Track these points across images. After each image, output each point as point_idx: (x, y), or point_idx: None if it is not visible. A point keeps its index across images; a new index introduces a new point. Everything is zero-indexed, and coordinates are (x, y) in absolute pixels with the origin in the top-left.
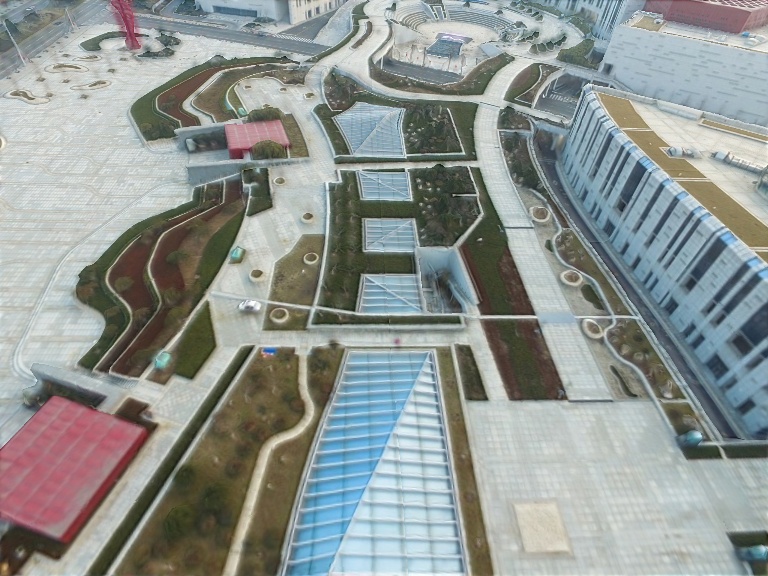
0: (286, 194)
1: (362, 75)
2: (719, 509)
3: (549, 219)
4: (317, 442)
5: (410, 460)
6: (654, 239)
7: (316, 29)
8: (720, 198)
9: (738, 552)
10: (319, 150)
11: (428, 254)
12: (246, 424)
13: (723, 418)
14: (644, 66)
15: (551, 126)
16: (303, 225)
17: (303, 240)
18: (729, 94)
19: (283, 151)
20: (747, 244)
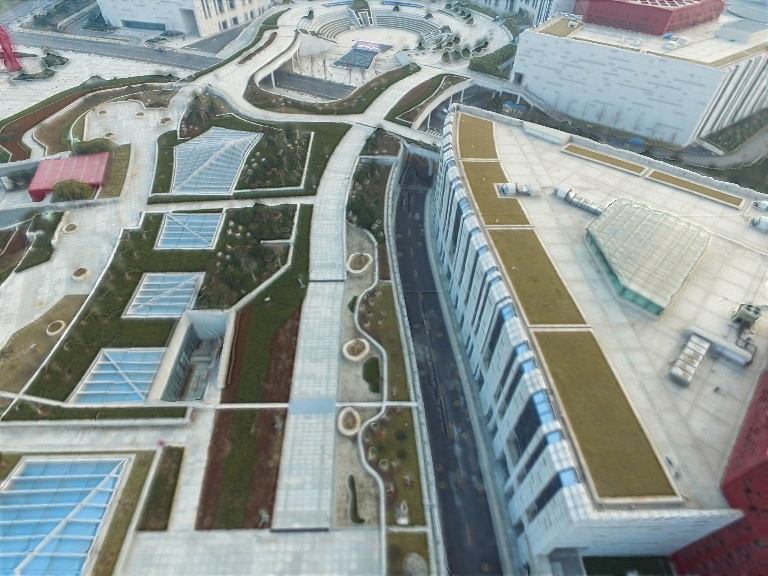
0: (73, 243)
1: (235, 95)
2: None
3: (366, 269)
4: None
5: None
6: (468, 298)
7: (226, 41)
8: (531, 253)
9: None
10: (138, 187)
11: (200, 319)
12: None
13: (493, 540)
14: (554, 75)
15: (423, 150)
16: (72, 283)
17: (62, 303)
18: (644, 105)
19: (91, 191)
20: (529, 320)
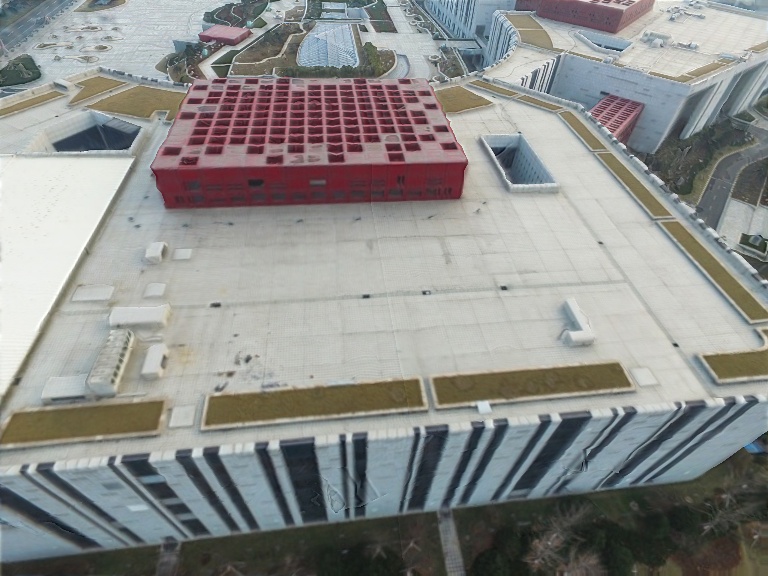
0: None
1: None
2: (439, 45)
3: (408, 4)
4: (308, 34)
5: (339, 33)
6: (448, 3)
7: None
8: None
9: (439, 48)
10: None
11: (351, 11)
12: (284, 30)
13: None
14: None
15: None
16: (295, 4)
17: (296, 7)
18: None
19: None
20: None
